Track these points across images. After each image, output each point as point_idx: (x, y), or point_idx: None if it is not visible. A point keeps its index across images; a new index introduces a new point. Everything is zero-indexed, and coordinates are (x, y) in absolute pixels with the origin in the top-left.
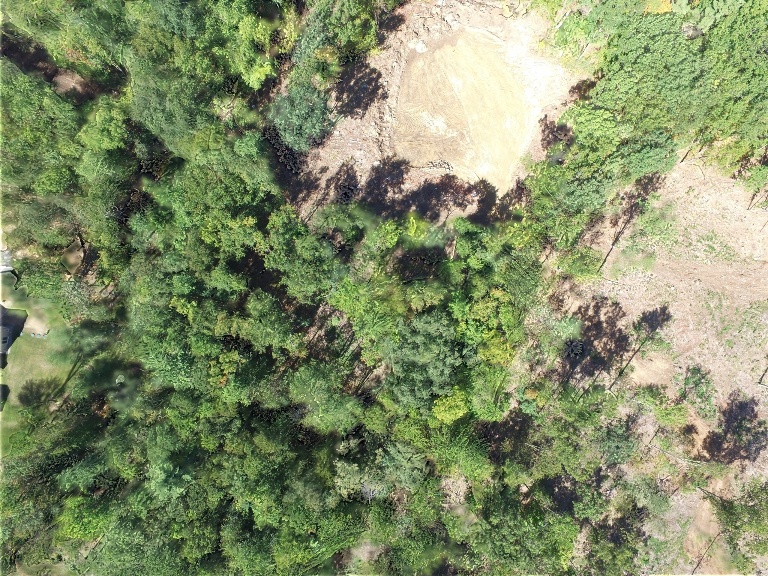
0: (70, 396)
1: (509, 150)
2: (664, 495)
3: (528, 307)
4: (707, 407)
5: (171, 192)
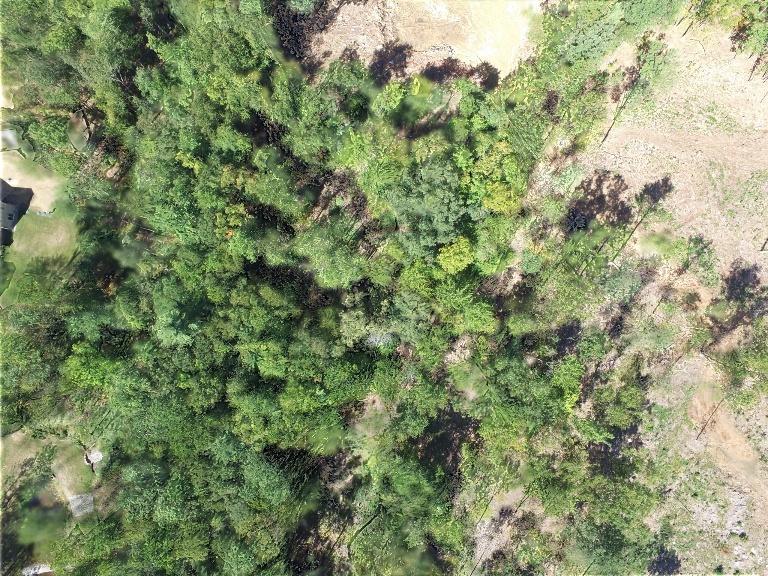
0: (76, 274)
1: (511, 34)
2: (668, 363)
3: (531, 181)
4: (710, 275)
5: (177, 50)
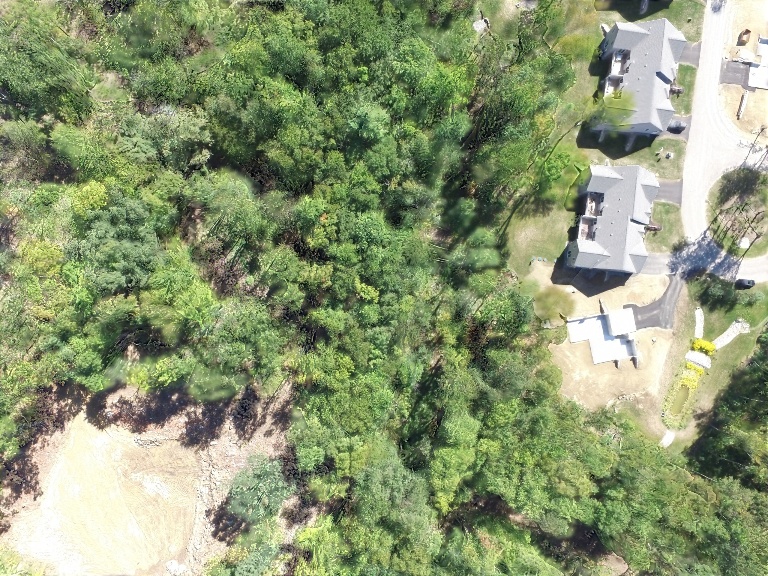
0: (507, 201)
1: (75, 462)
2: None
3: None
4: None
5: None
